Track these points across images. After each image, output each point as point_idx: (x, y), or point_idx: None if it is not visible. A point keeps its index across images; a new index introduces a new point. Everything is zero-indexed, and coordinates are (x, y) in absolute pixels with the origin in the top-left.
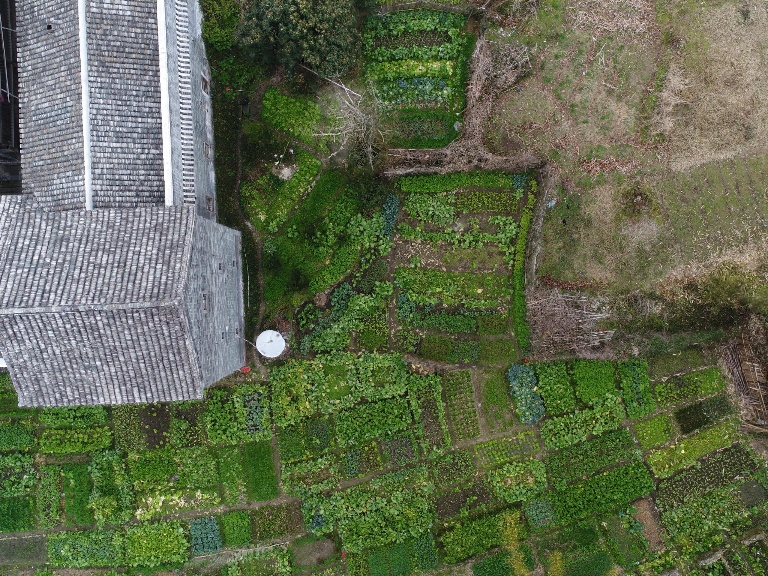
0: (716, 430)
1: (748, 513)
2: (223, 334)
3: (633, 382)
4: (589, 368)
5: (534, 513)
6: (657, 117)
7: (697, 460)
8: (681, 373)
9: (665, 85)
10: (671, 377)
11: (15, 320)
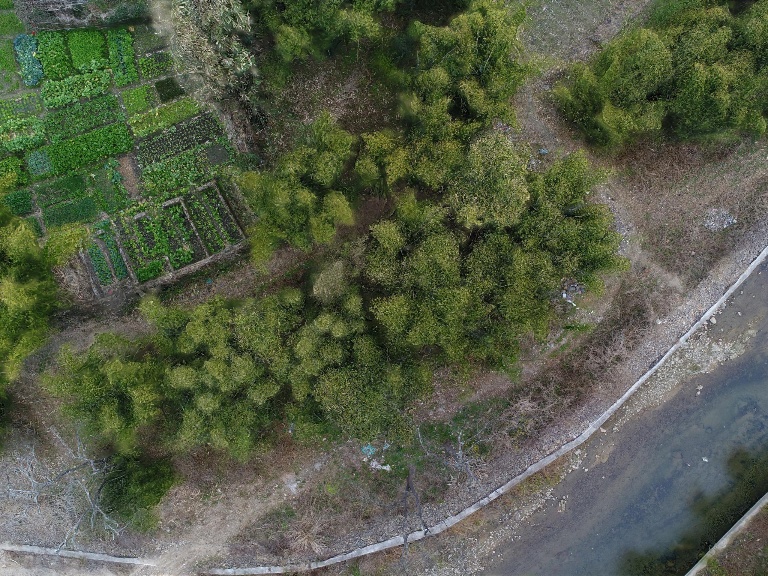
0: (189, 99)
1: (215, 172)
2: None
3: (119, 54)
4: (79, 38)
5: (34, 163)
6: None
7: (172, 124)
8: (163, 50)
9: None
10: (154, 53)
11: None
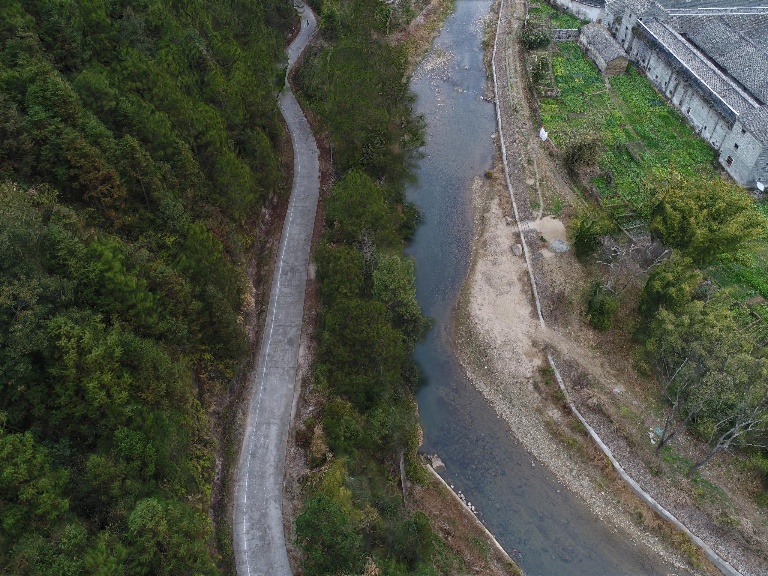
0: None
1: None
2: (767, 165)
3: None
4: None
5: None
6: None
7: None
8: None
9: None
10: None
11: (767, 108)
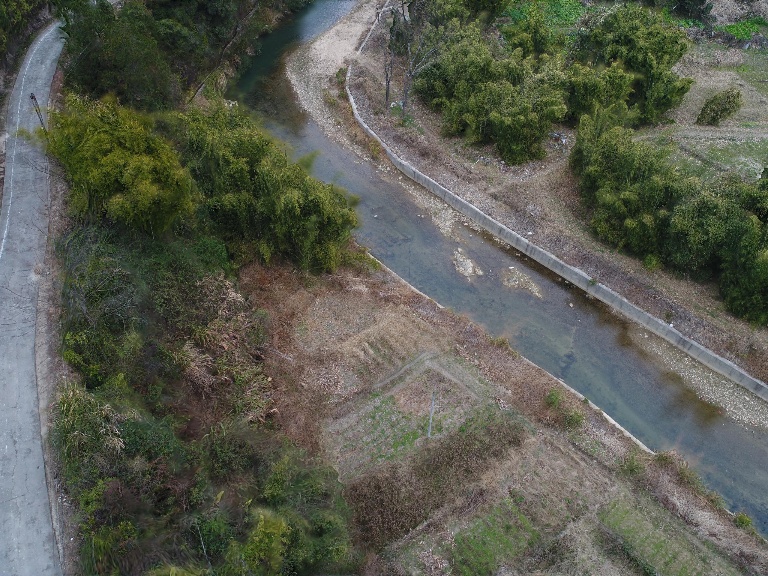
0: None
1: None
2: None
3: None
4: None
5: None
6: None
7: None
8: None
9: None
10: None
11: None
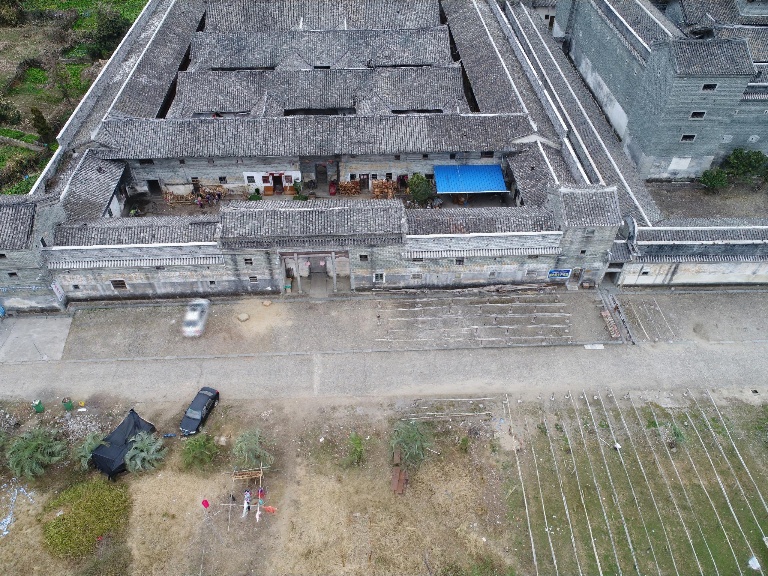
0: None
1: None
2: None
3: None
4: None
5: None
6: (8, 44)
7: None
8: None
9: (0, 49)
10: None
11: None
